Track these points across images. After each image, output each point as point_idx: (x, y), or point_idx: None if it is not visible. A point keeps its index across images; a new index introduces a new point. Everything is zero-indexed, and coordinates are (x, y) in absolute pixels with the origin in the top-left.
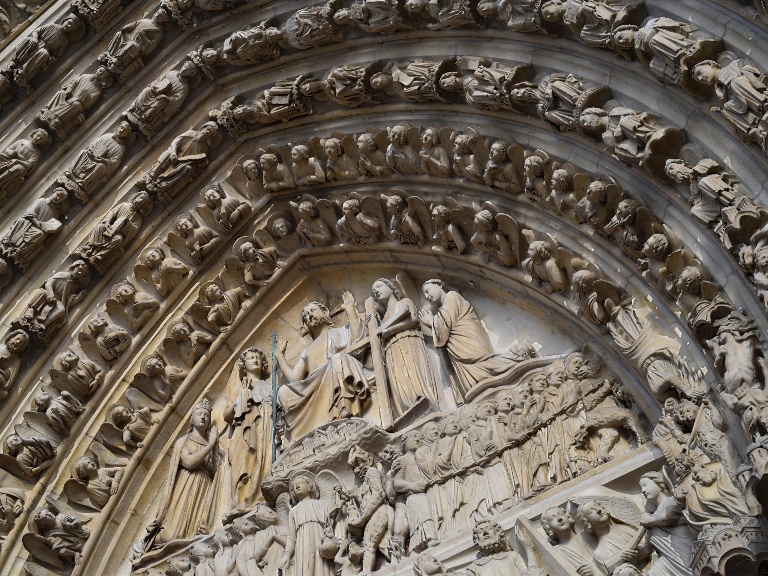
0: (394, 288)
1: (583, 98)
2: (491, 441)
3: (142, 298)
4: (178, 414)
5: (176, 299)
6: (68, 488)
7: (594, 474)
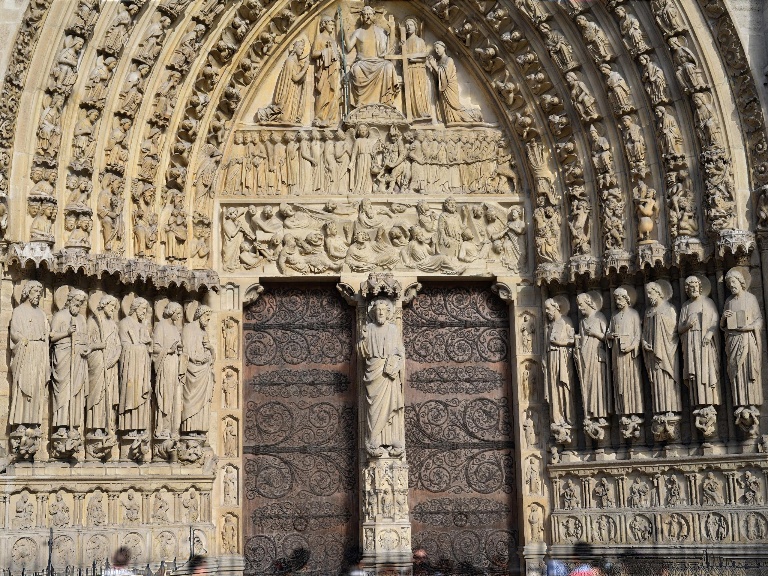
0: (417, 28)
1: (572, 66)
2: (457, 157)
3: None
4: (285, 38)
5: None
6: (238, 73)
7: (496, 196)
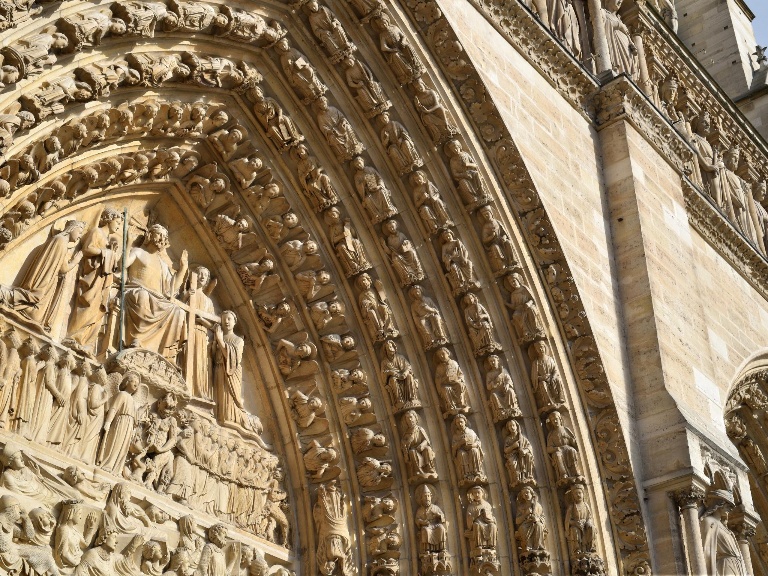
0: None
1: None
2: None
3: None
4: None
5: (126, 139)
6: (13, 216)
7: None
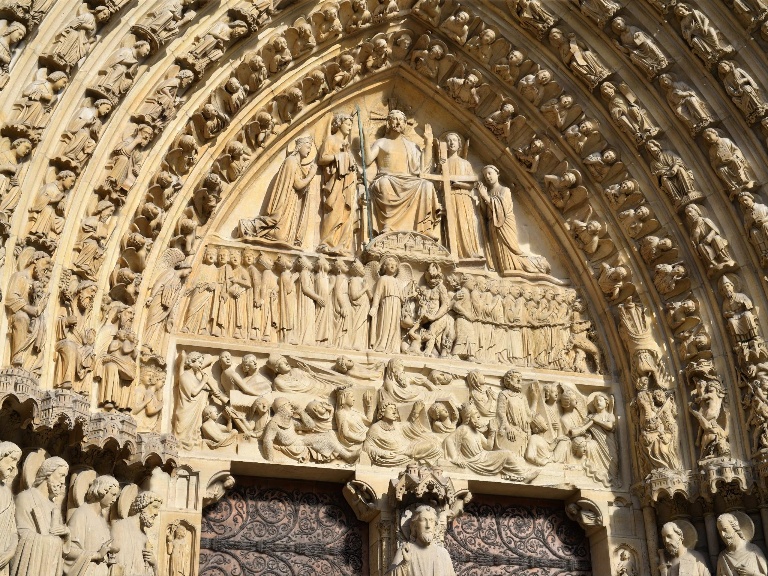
0: (461, 146)
1: (695, 196)
2: (519, 316)
3: (312, 40)
4: None
5: (323, 48)
6: (223, 159)
7: (573, 375)
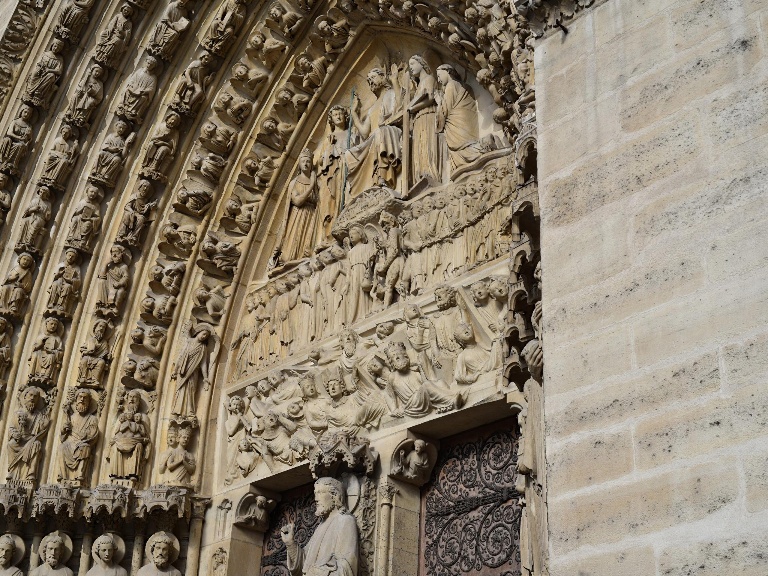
0: (423, 64)
1: None
2: (458, 220)
3: (254, 75)
4: (292, 158)
5: (280, 70)
6: (223, 222)
7: (506, 258)
